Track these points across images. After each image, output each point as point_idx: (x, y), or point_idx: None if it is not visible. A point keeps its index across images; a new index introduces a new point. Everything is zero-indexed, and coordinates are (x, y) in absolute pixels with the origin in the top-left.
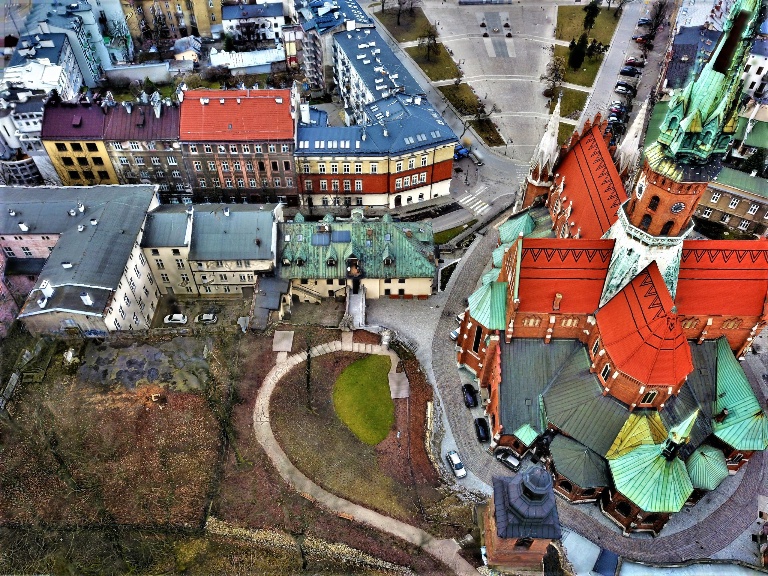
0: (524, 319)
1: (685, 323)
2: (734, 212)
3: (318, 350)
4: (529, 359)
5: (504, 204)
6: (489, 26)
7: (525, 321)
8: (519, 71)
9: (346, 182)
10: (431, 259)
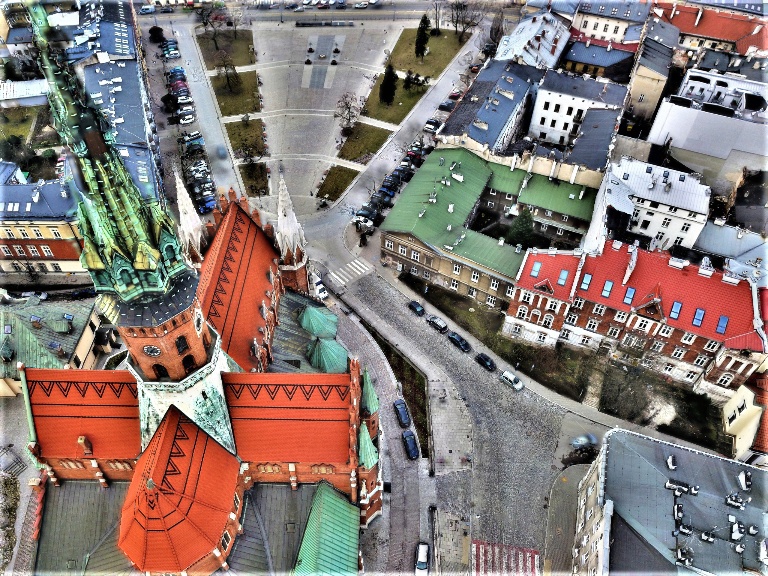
0: (59, 462)
1: (264, 468)
2: (478, 286)
3: None
4: (81, 507)
5: None
6: (317, 51)
7: (64, 463)
8: (326, 105)
9: (31, 247)
10: (61, 355)
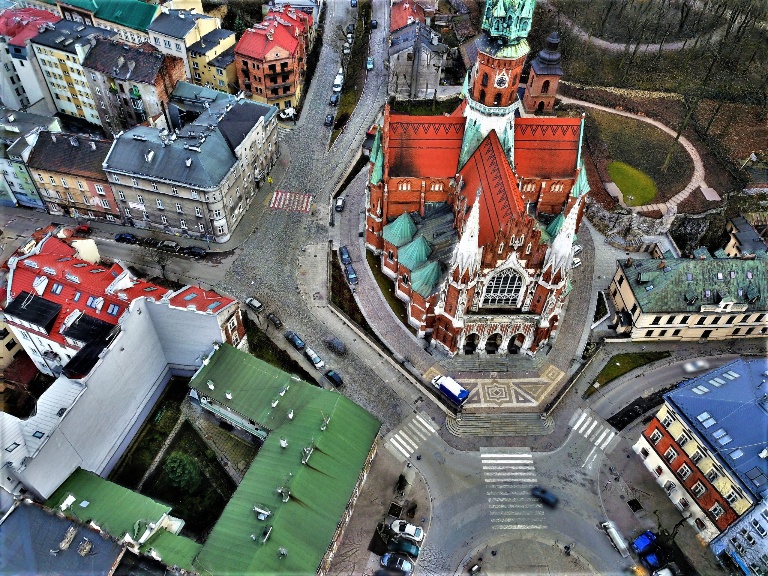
0: None
1: None
2: None
3: (681, 197)
4: None
5: (554, 429)
6: None
7: None
8: None
9: None
10: None
